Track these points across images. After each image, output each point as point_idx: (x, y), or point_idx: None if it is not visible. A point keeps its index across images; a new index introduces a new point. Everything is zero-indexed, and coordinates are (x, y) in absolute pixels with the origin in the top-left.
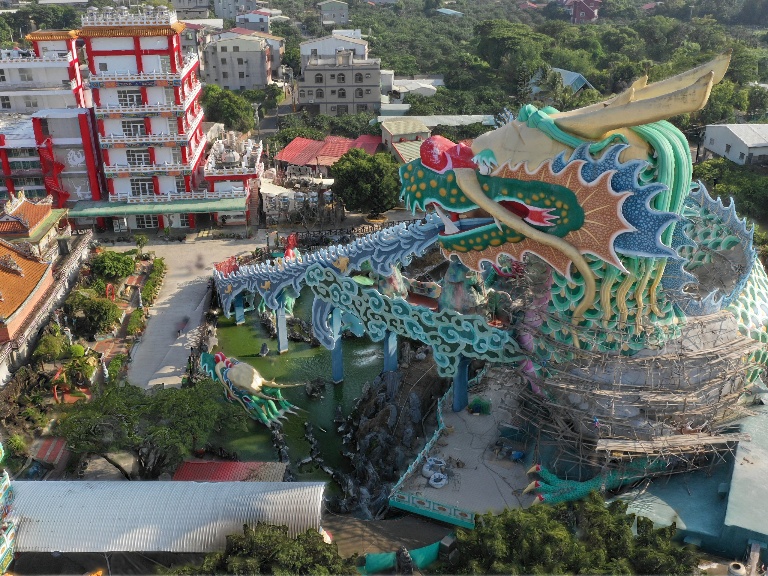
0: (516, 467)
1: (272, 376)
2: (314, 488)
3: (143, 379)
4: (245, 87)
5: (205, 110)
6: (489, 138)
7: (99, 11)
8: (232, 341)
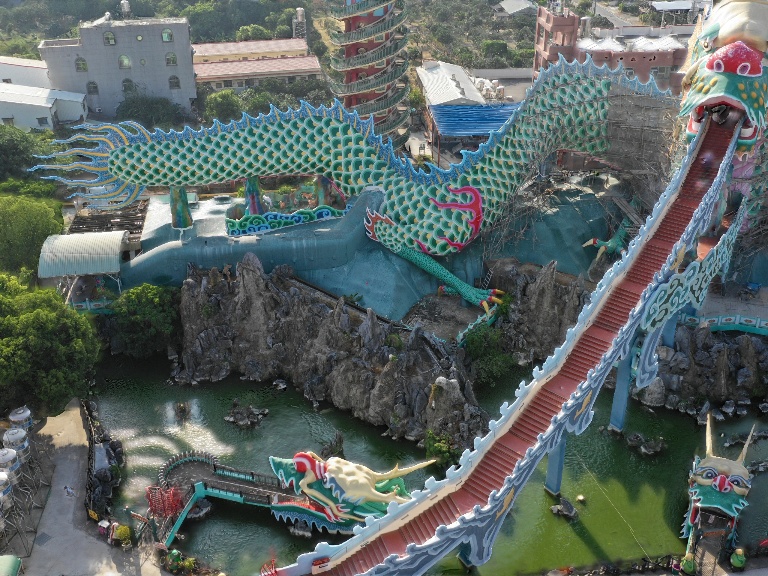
0: (765, 290)
1: (625, 495)
2: None
3: None
4: None
5: None
6: (763, 24)
7: None
8: (528, 565)
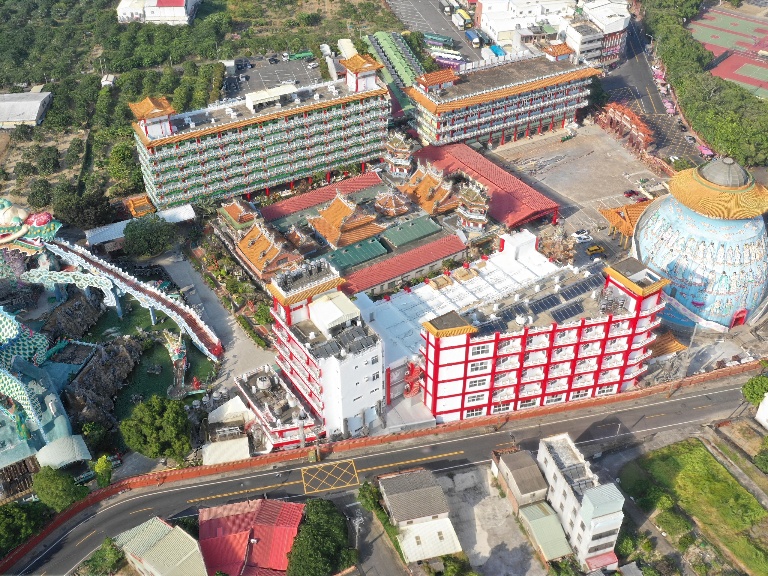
0: None
1: None
2: (90, 236)
3: (198, 285)
4: None
5: (479, 574)
6: None
7: (319, 261)
8: None
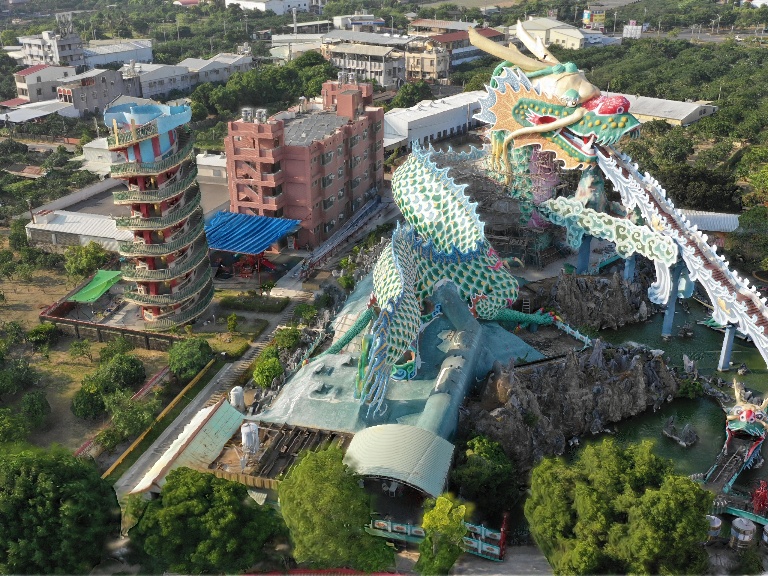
0: None
1: None
2: None
3: None
4: None
5: None
6: None
7: None
8: None
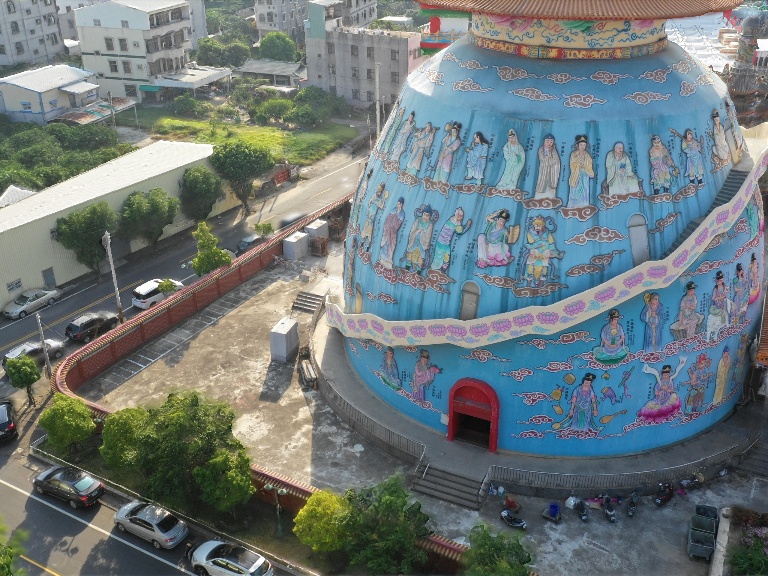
0: None
1: None
2: None
3: None
4: (193, 46)
5: None
6: None
7: None
8: None
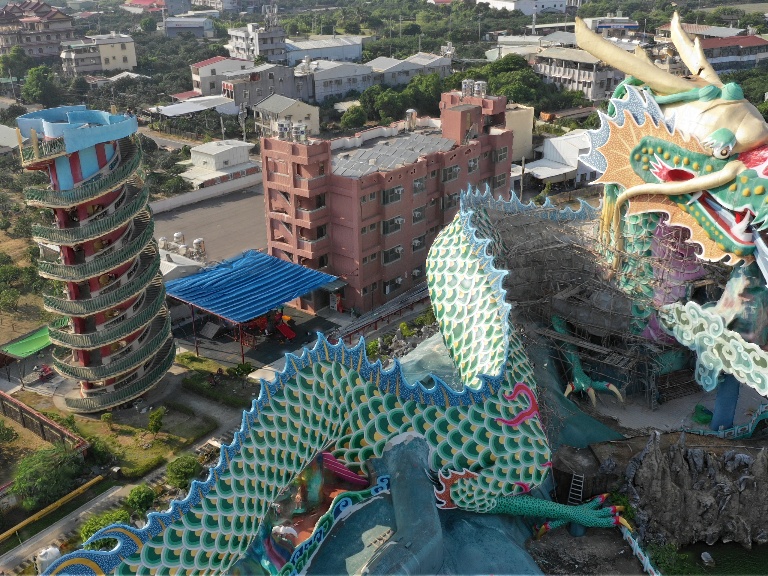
0: None
1: None
2: None
3: None
4: None
5: None
6: None
7: None
8: None
